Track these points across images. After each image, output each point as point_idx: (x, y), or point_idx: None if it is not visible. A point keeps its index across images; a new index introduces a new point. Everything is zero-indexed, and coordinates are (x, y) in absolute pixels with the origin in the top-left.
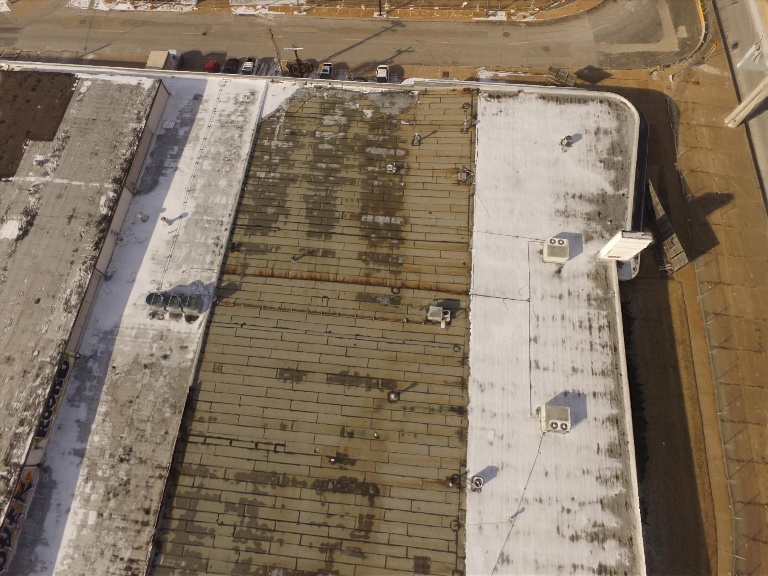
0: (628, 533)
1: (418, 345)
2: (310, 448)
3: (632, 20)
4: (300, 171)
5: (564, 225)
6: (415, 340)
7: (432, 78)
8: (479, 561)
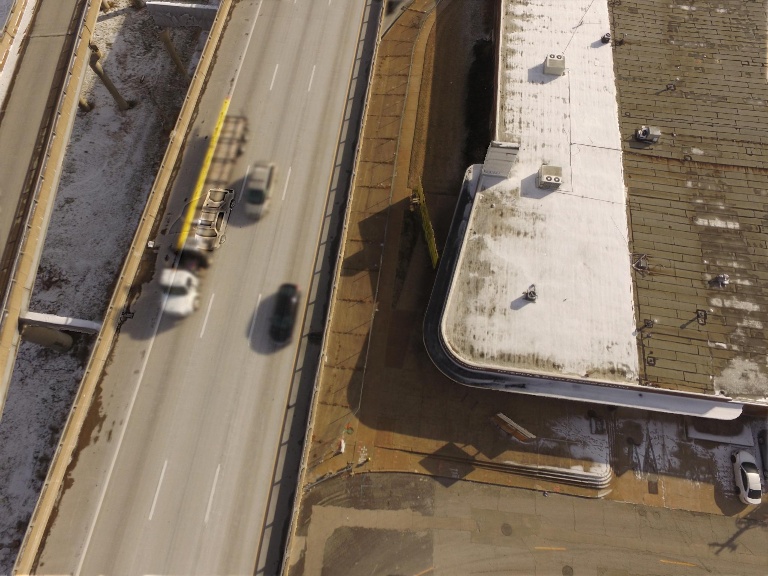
0: (508, 16)
1: (660, 118)
2: (724, 63)
3: None
4: None
5: (538, 205)
6: (663, 121)
7: (672, 481)
8: (600, 9)
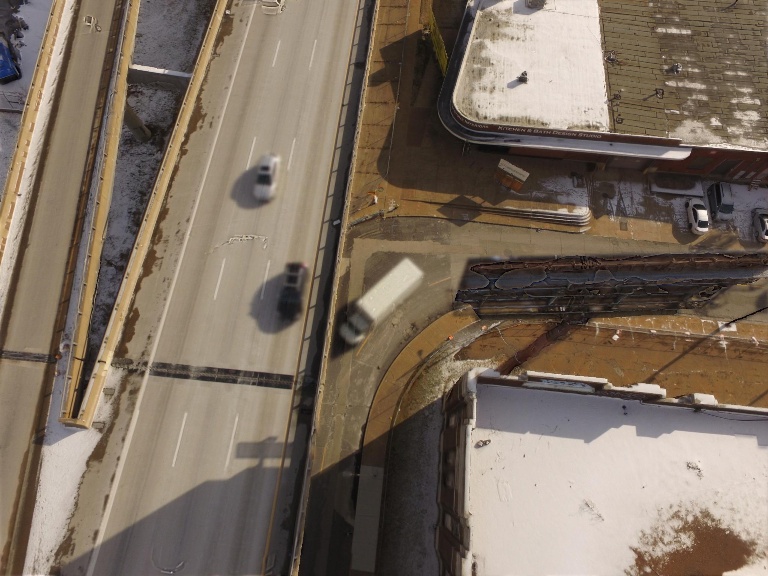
0: None
1: None
2: None
3: (399, 290)
4: (760, 69)
5: (527, 19)
6: None
7: (639, 222)
8: None
